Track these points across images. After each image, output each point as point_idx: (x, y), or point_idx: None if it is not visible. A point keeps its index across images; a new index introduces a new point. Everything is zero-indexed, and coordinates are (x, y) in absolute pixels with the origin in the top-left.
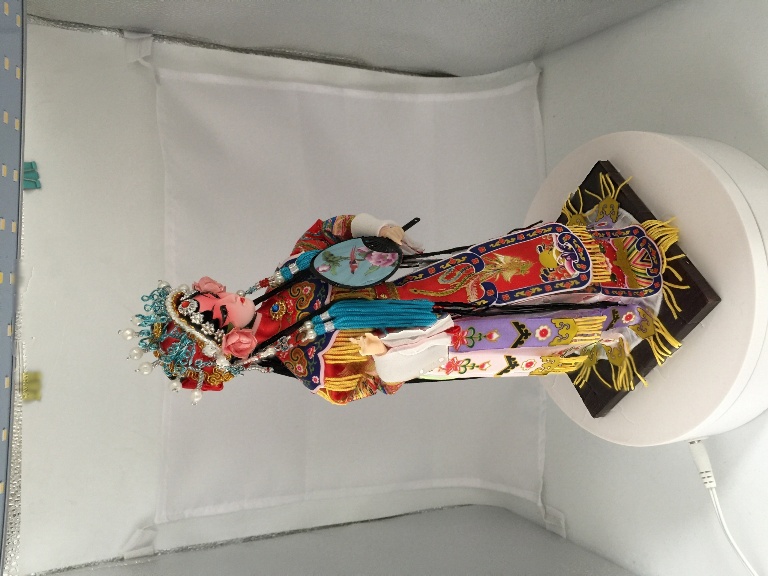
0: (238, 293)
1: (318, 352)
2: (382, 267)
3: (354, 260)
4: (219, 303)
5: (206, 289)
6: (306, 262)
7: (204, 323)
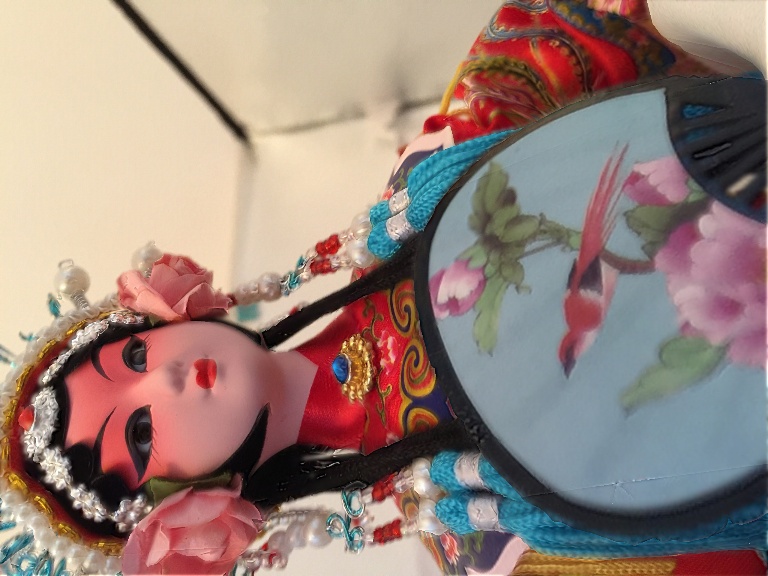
0: (261, 285)
1: (465, 564)
2: (741, 368)
3: (595, 260)
4: (128, 401)
5: (144, 306)
6: (427, 207)
7: (76, 486)
